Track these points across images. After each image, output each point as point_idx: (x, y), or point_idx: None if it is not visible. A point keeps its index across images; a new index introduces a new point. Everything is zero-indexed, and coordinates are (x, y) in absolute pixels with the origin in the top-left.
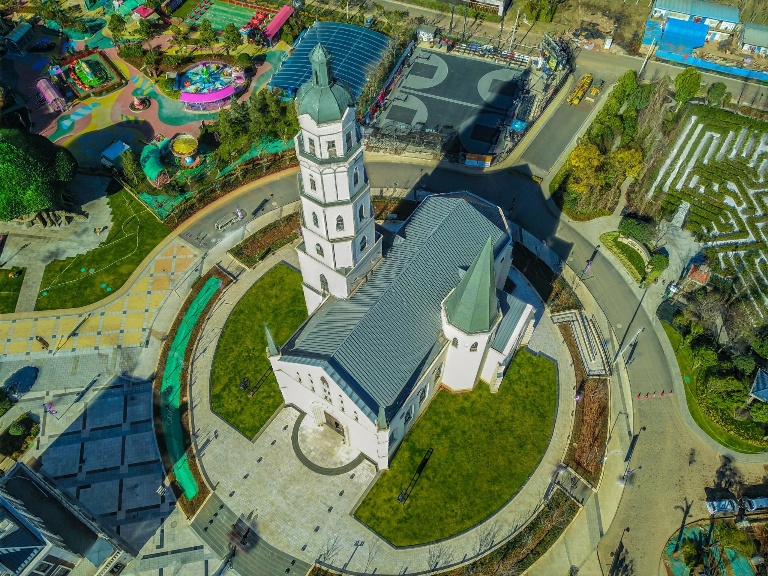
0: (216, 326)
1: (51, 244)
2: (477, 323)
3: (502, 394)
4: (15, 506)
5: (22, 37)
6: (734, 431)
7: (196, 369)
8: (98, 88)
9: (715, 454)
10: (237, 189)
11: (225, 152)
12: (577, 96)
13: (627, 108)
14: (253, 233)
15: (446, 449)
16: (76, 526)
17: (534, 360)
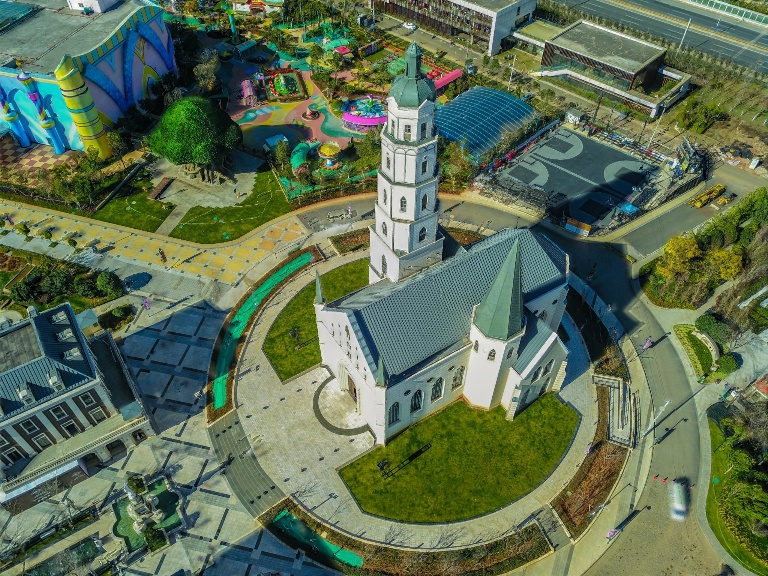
0: (294, 289)
1: (201, 194)
2: (496, 328)
3: (516, 424)
4: (90, 354)
5: (247, 50)
6: (747, 544)
7: (265, 315)
8: (285, 97)
9: (718, 560)
10: (358, 194)
11: (360, 165)
12: (701, 199)
13: (750, 222)
14: (355, 230)
15: (443, 450)
16: (125, 389)
17: (560, 406)
